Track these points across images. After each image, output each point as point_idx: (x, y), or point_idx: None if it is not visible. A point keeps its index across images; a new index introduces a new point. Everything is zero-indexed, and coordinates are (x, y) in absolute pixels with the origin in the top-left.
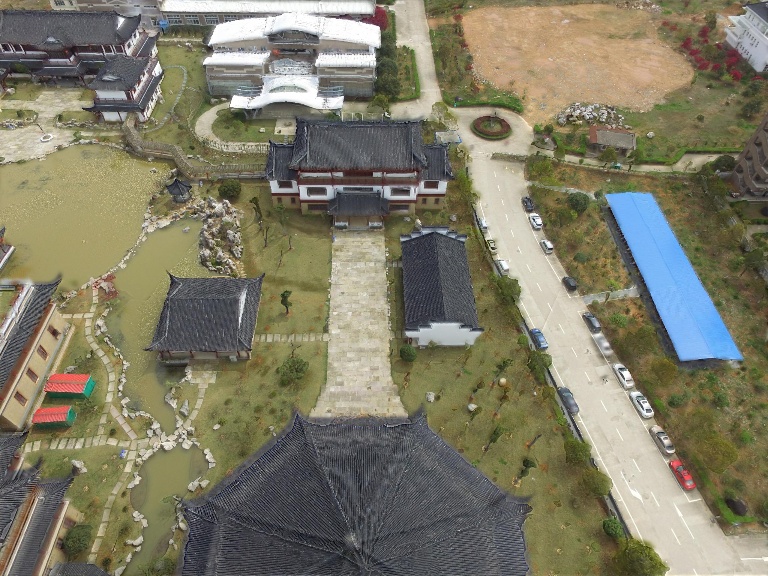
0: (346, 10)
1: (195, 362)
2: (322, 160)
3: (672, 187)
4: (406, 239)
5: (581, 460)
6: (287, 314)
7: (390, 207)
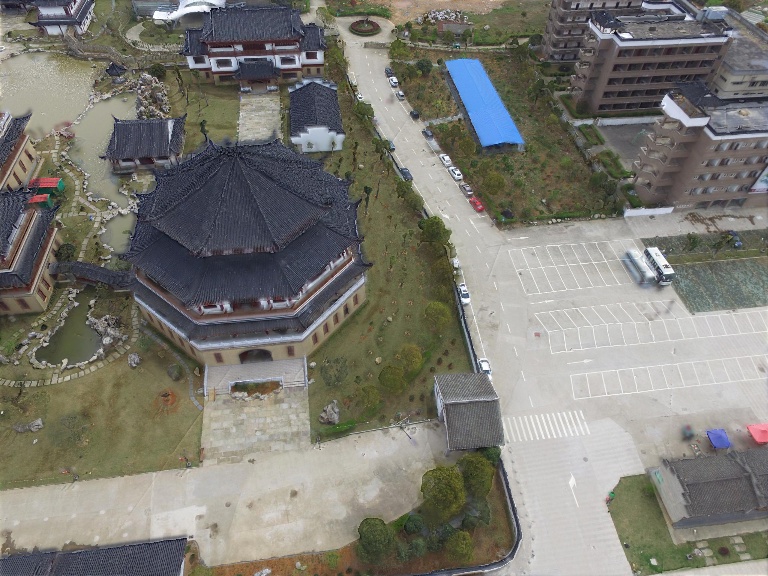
0: None
1: (139, 171)
2: (225, 35)
3: (497, 58)
4: (293, 90)
5: (405, 191)
6: (206, 142)
7: (283, 76)
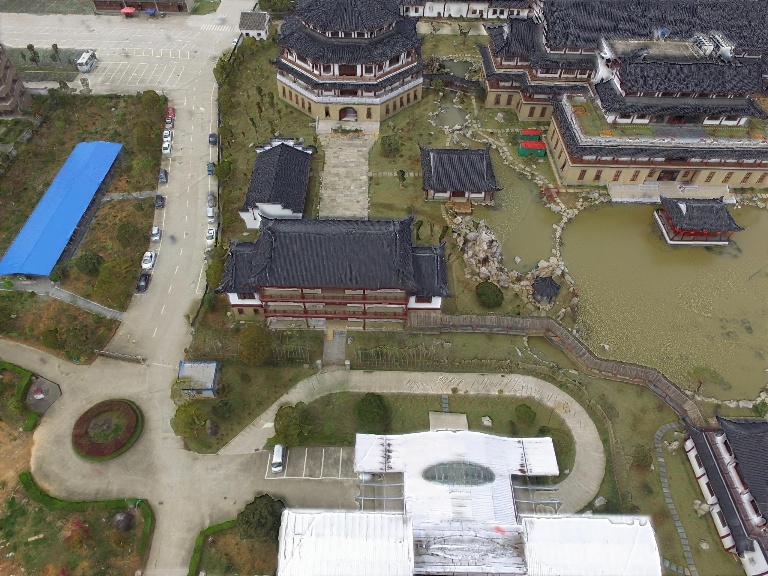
0: None
1: None
2: None
3: None
4: (296, 215)
5: None
6: None
7: None
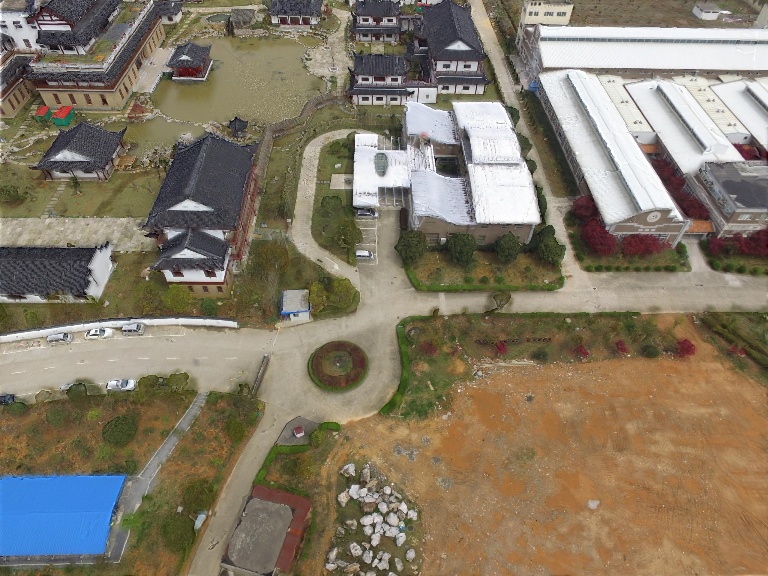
0: (604, 198)
1: None
2: None
3: None
4: None
5: None
6: None
7: None
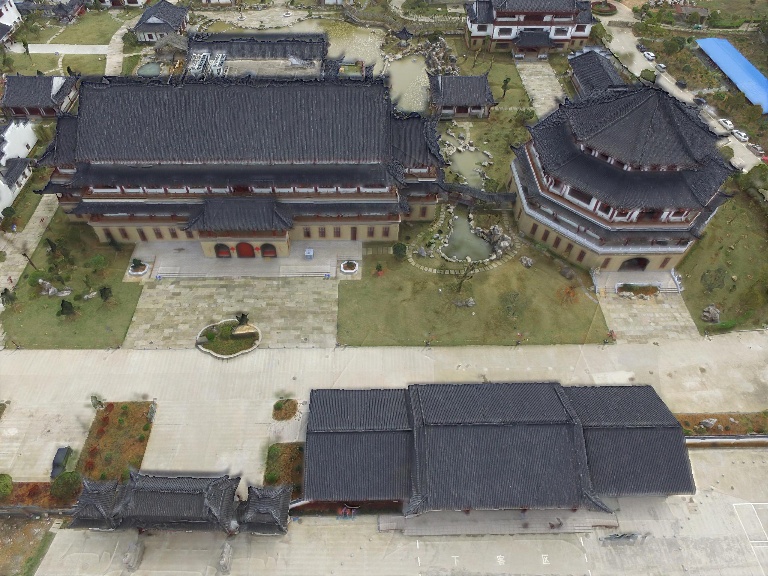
0: None
1: (456, 118)
2: (515, 6)
3: (739, 39)
4: (572, 57)
5: None
6: (503, 98)
7: None
